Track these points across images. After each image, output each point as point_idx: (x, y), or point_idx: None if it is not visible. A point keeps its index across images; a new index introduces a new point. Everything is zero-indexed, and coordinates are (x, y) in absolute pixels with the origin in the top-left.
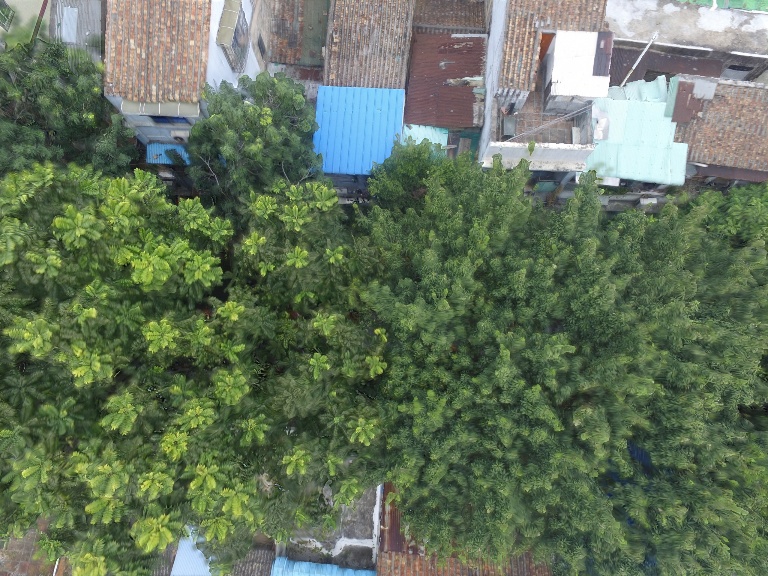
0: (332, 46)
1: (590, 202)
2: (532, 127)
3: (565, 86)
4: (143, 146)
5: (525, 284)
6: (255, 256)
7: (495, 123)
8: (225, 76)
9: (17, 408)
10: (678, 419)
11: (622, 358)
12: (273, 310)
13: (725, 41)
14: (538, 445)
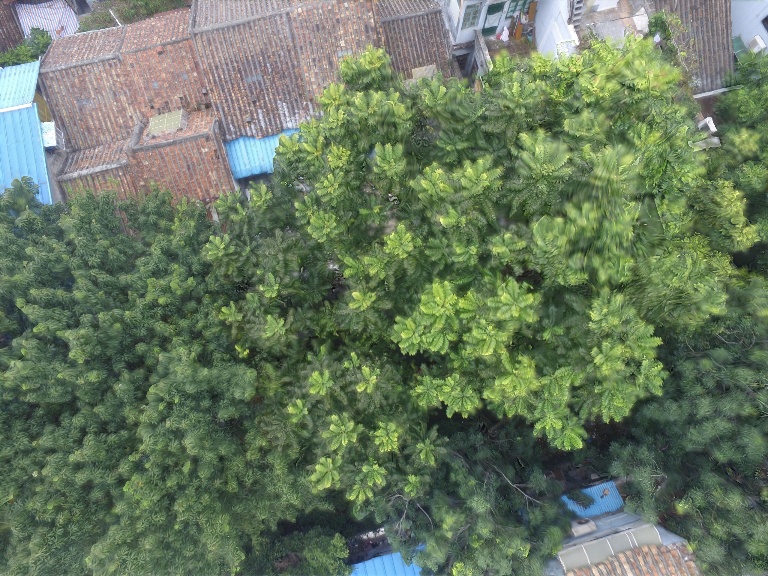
0: None
1: None
2: None
3: None
4: None
5: None
6: None
7: None
8: None
9: (488, 136)
10: None
11: None
12: None
13: None
14: None
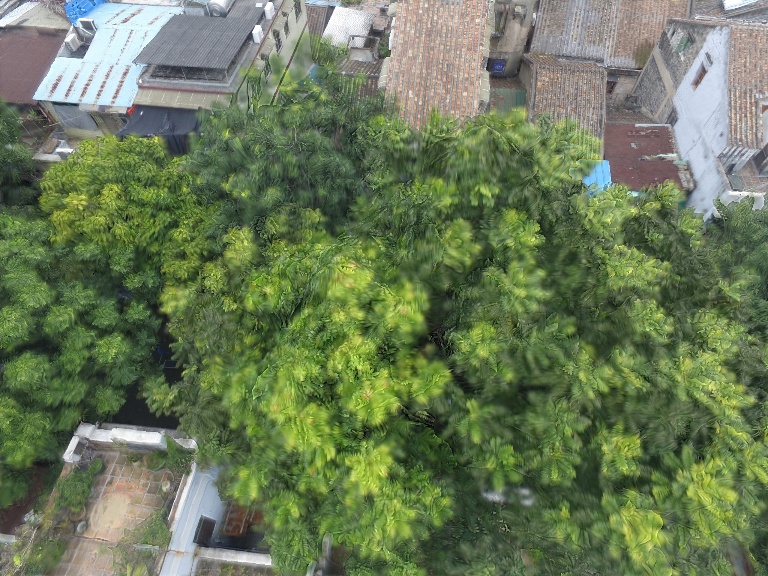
0: None
1: None
2: (752, 186)
3: None
4: None
5: None
6: (644, 220)
7: (726, 177)
8: None
9: None
10: None
11: None
12: None
13: None
14: None
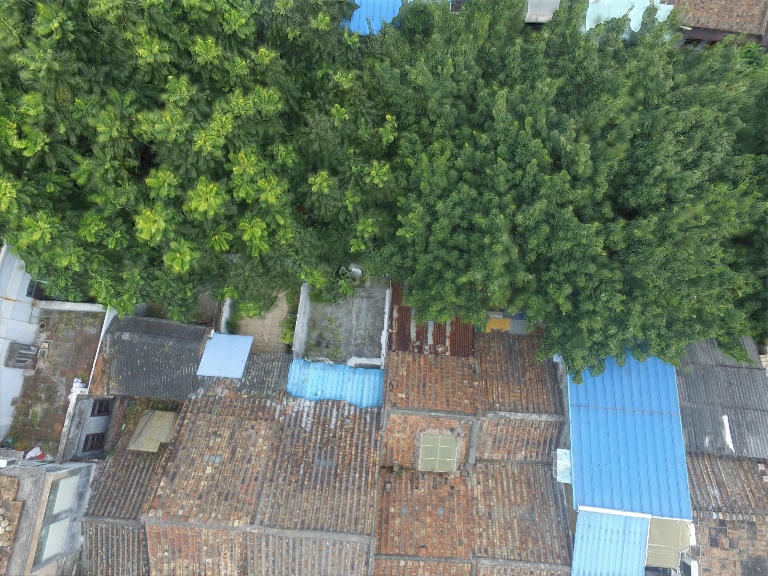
0: None
1: (579, 0)
2: None
3: None
4: None
5: (520, 65)
6: (283, 19)
7: None
8: None
9: None
10: (652, 157)
11: None
12: None
13: None
14: (530, 193)
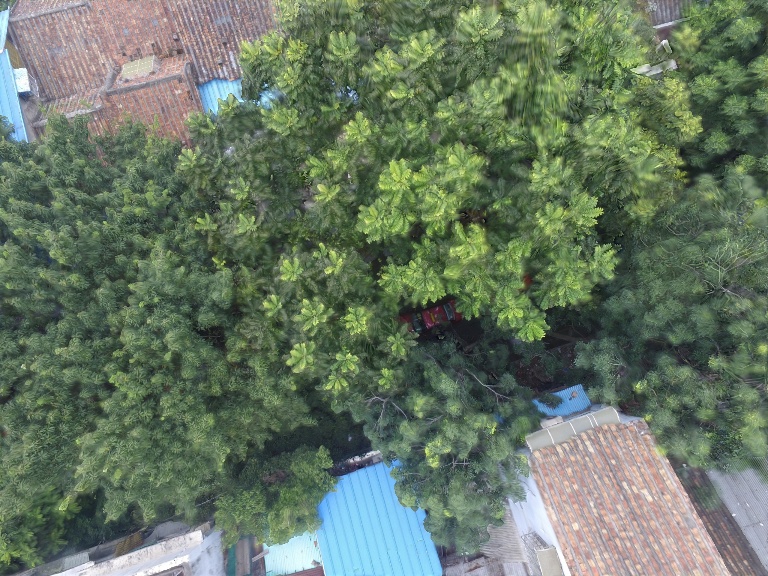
0: None
1: (8, 476)
2: None
3: None
4: (596, 403)
5: None
6: None
7: None
8: None
9: (437, 24)
10: None
11: None
12: None
13: None
14: None
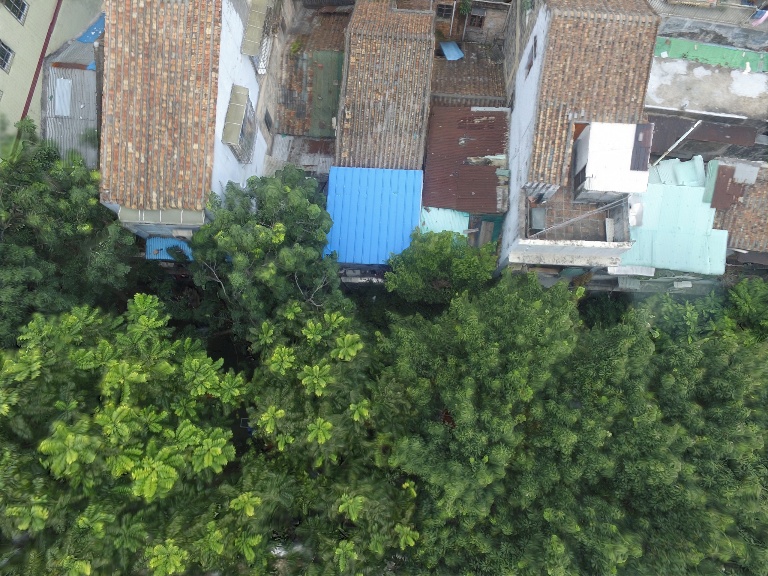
0: (344, 123)
1: (642, 342)
2: (562, 217)
3: (600, 181)
4: (142, 239)
5: None
6: (272, 431)
7: (523, 218)
8: (231, 171)
9: None
10: None
11: (694, 557)
12: (290, 470)
13: (760, 108)
14: None
